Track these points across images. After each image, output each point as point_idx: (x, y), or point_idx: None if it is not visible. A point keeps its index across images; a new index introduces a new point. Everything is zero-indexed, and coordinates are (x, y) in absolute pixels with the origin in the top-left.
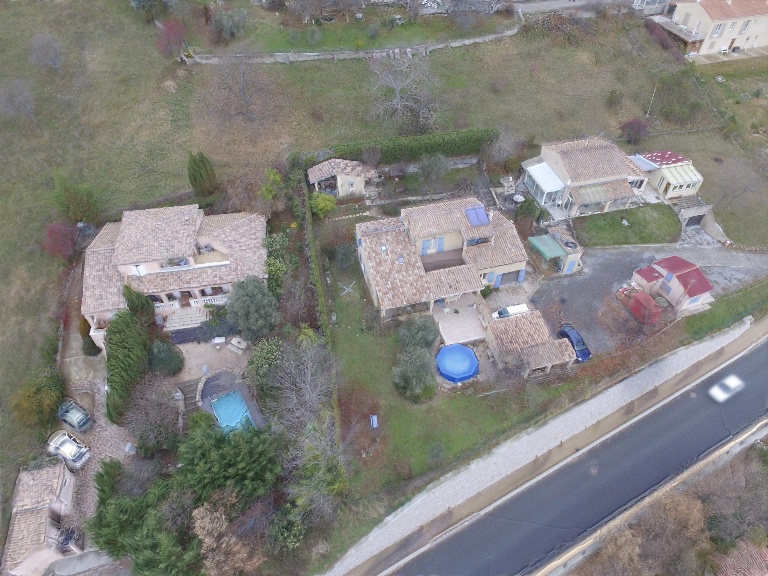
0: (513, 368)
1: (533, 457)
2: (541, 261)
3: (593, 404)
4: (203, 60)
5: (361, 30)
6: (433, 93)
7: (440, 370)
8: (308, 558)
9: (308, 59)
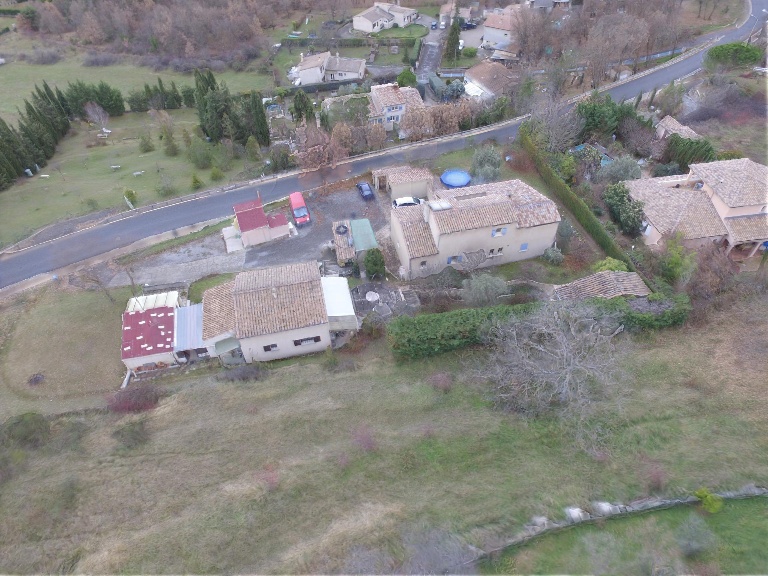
0: None
1: None
2: None
3: None
4: None
5: None
6: (501, 423)
7: None
8: None
9: None
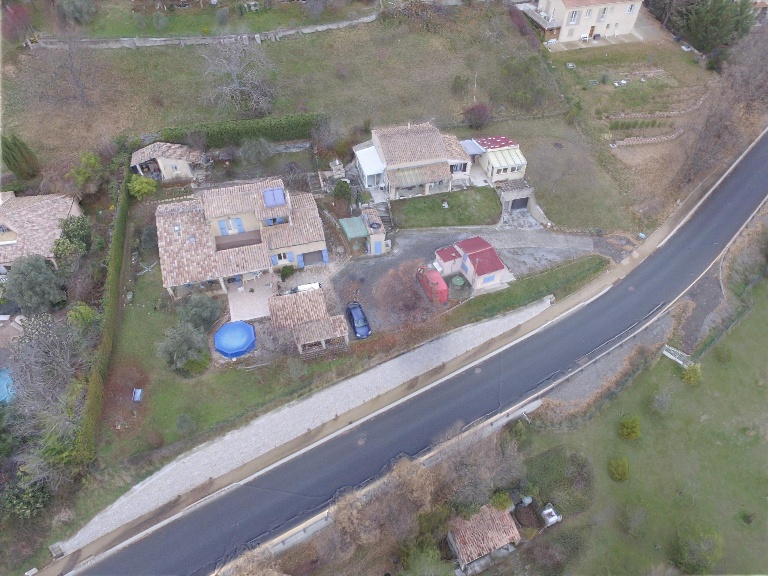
0: (291, 344)
1: (305, 430)
2: (354, 242)
3: (365, 378)
4: (48, 45)
5: (212, 16)
6: (276, 78)
7: (215, 346)
8: (48, 525)
9: (155, 44)
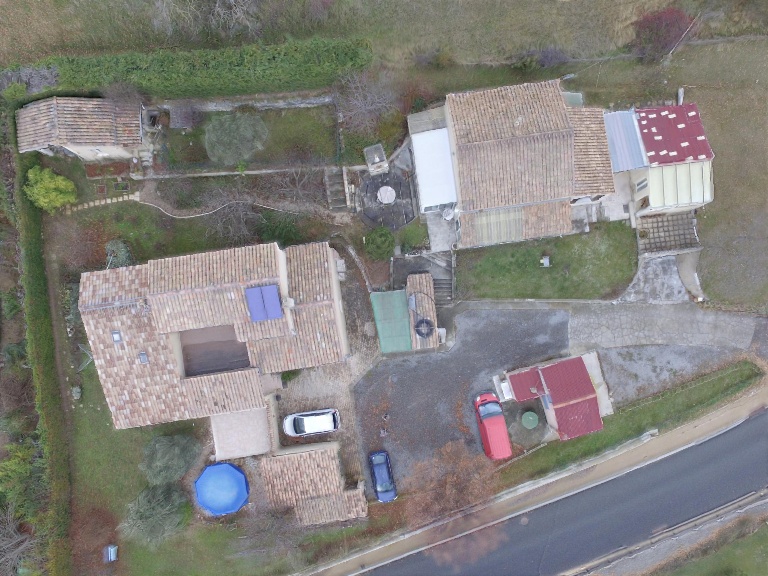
0: None
1: None
2: None
3: None
4: None
5: None
6: None
7: (198, 501)
8: None
9: None
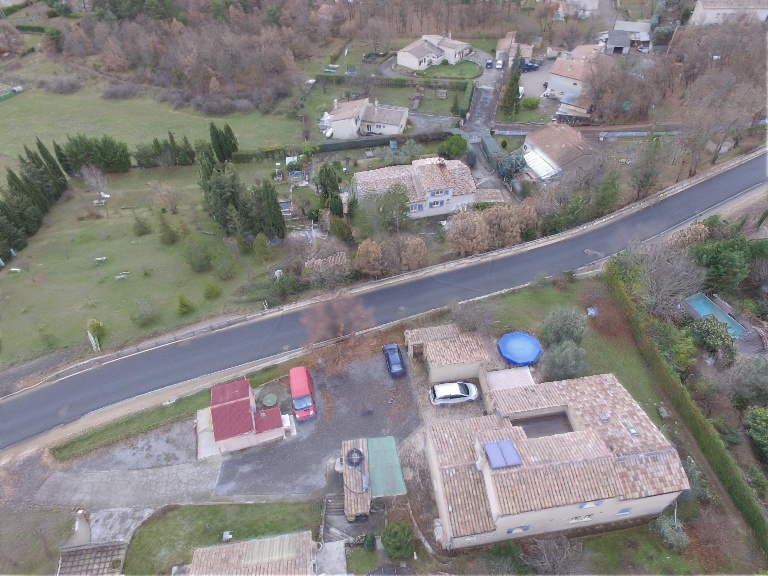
0: None
1: None
2: None
3: None
4: None
5: None
6: None
7: None
8: None
9: None
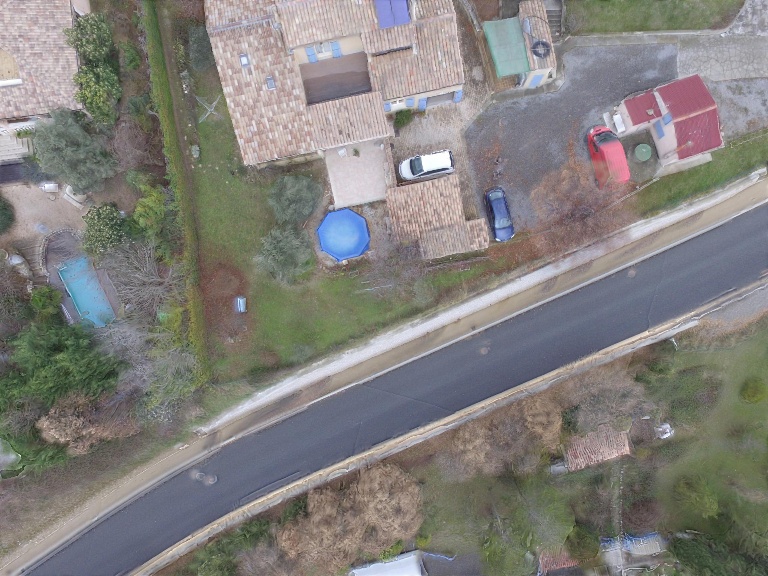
0: (413, 246)
1: (424, 334)
2: None
3: (499, 292)
4: None
5: None
6: None
7: (321, 247)
8: (188, 421)
9: None
